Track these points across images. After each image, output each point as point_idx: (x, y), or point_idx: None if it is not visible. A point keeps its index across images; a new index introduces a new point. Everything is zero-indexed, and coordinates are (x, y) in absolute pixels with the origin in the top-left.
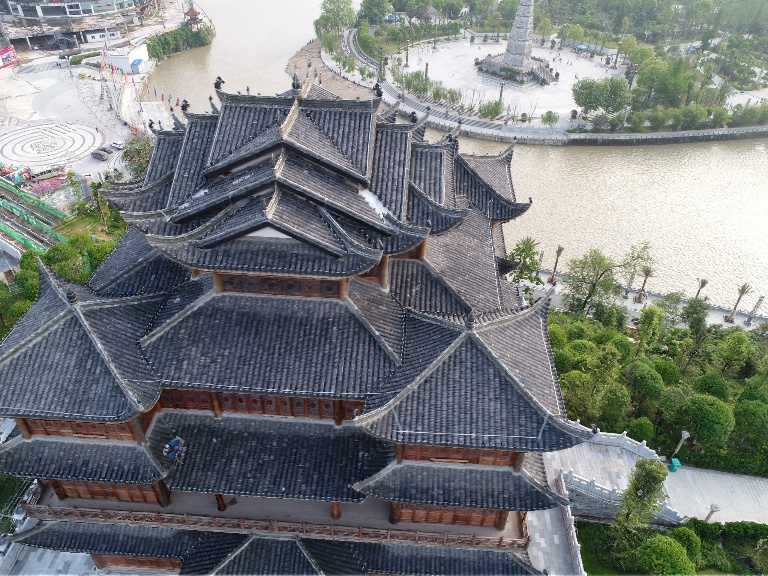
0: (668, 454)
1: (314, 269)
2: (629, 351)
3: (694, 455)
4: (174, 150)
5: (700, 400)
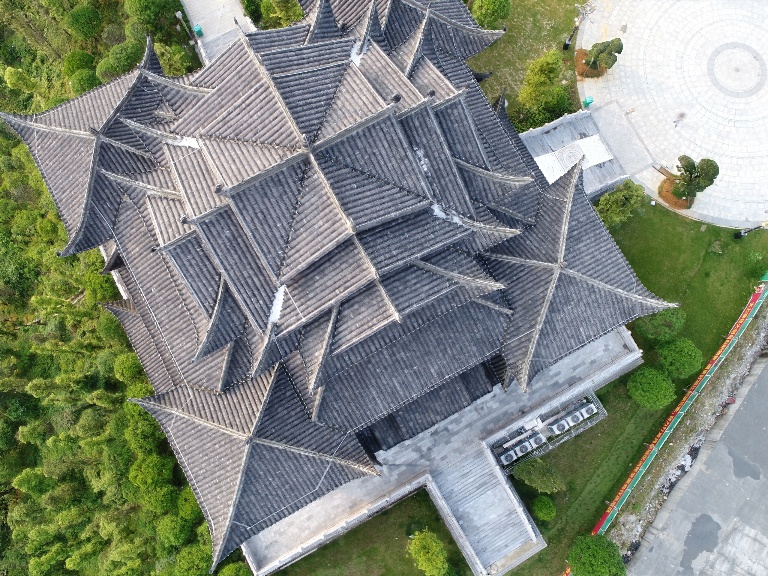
0: (187, 38)
1: (447, 78)
2: (63, 100)
3: (182, 18)
4: (402, 287)
5: (143, 2)
